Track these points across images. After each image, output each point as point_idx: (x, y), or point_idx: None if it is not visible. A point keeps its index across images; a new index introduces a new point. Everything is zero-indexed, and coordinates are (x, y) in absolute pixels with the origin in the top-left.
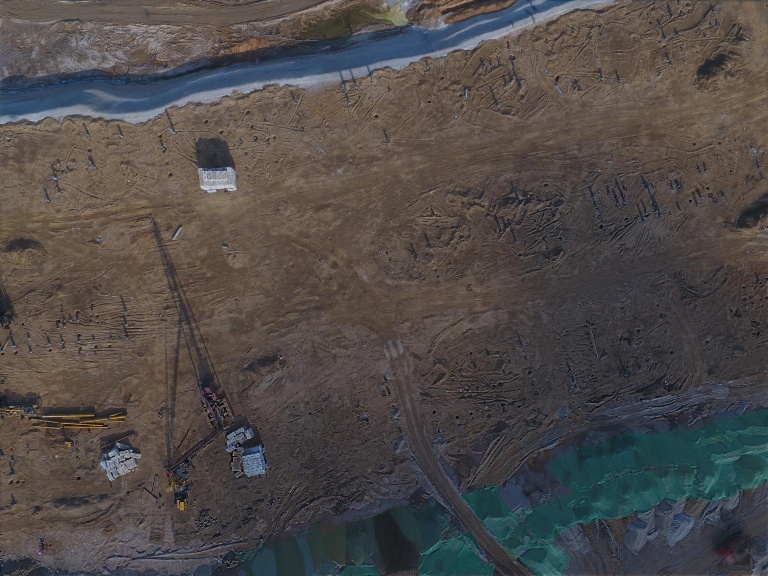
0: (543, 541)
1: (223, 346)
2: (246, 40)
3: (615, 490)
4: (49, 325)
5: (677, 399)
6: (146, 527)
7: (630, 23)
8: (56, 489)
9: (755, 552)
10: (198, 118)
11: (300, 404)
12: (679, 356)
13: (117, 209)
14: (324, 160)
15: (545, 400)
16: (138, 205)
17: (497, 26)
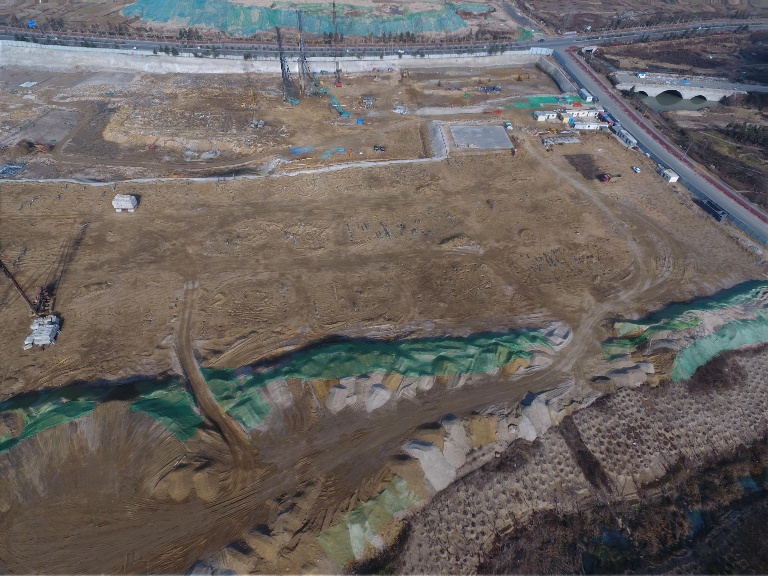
0: (251, 390)
1: (74, 275)
2: (178, 174)
3: (325, 364)
4: None
5: (394, 328)
6: None
7: (380, 172)
8: None
9: (445, 421)
10: (131, 187)
11: (106, 309)
12: (397, 303)
13: (57, 214)
14: (192, 205)
15: (292, 321)
16: (71, 214)
17: None
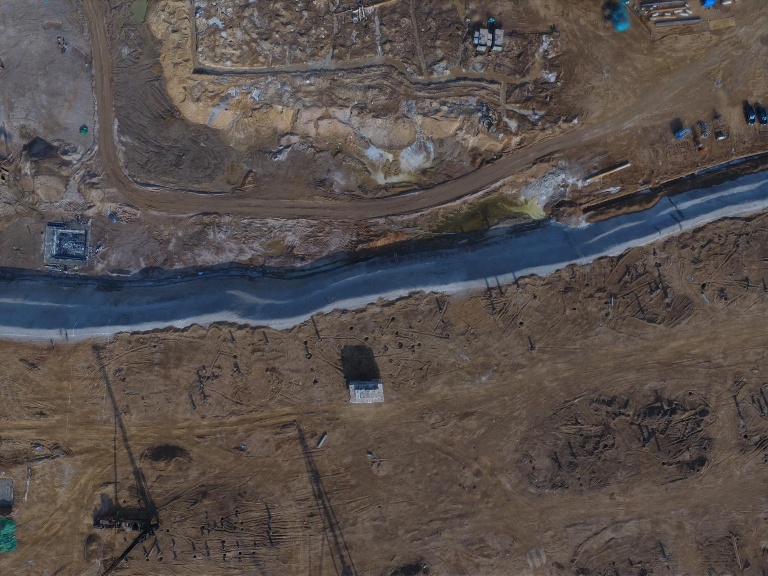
0: None
1: (367, 554)
2: (384, 234)
3: None
4: (194, 531)
5: None
6: None
7: None
8: None
9: None
10: (343, 325)
11: None
12: None
13: (262, 415)
14: (469, 367)
15: None
16: (283, 411)
17: (643, 232)
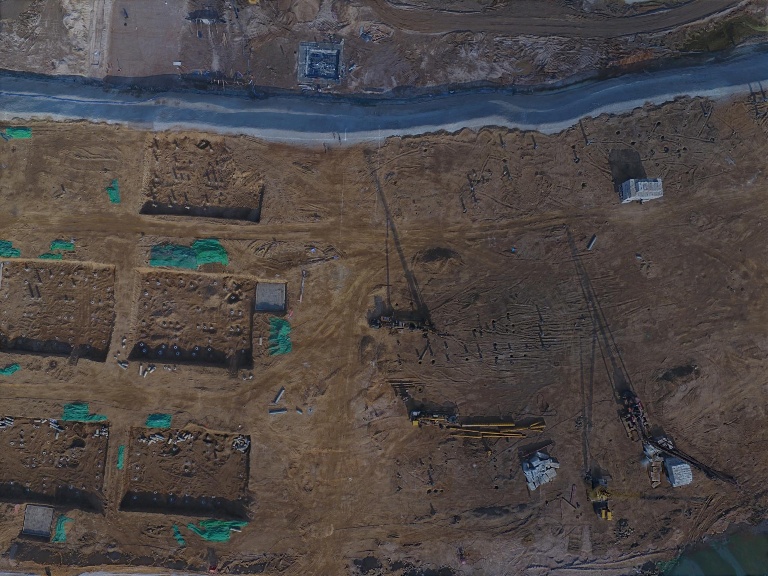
0: None
1: (637, 356)
2: (633, 52)
3: None
4: (466, 334)
5: None
6: (564, 537)
7: None
8: (474, 498)
9: None
10: (610, 129)
11: (715, 414)
12: None
13: (531, 219)
14: (734, 171)
15: None
16: (552, 215)
17: None
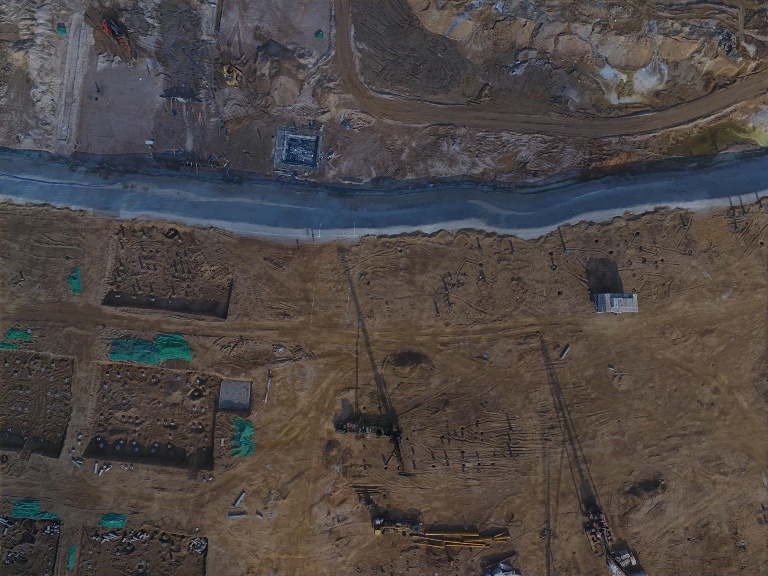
0: None
1: (605, 468)
2: (616, 153)
3: None
4: (433, 440)
5: None
6: None
7: None
8: None
9: None
10: (589, 237)
11: (679, 529)
12: None
13: (505, 325)
14: (710, 285)
15: None
16: (526, 322)
17: None
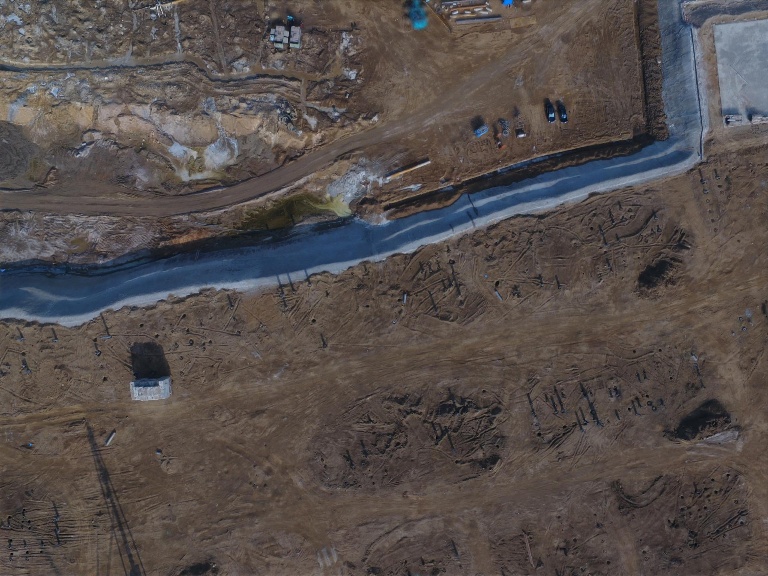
0: None
1: (156, 553)
2: (187, 231)
3: None
4: None
5: None
6: None
7: (571, 229)
8: None
9: None
10: (133, 322)
11: None
12: (616, 566)
13: (51, 413)
14: (260, 365)
15: None
16: (72, 409)
17: (437, 229)
